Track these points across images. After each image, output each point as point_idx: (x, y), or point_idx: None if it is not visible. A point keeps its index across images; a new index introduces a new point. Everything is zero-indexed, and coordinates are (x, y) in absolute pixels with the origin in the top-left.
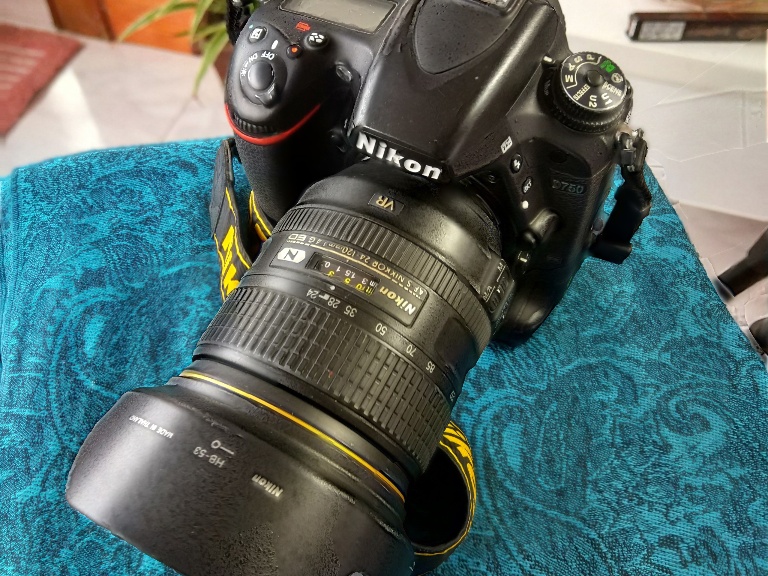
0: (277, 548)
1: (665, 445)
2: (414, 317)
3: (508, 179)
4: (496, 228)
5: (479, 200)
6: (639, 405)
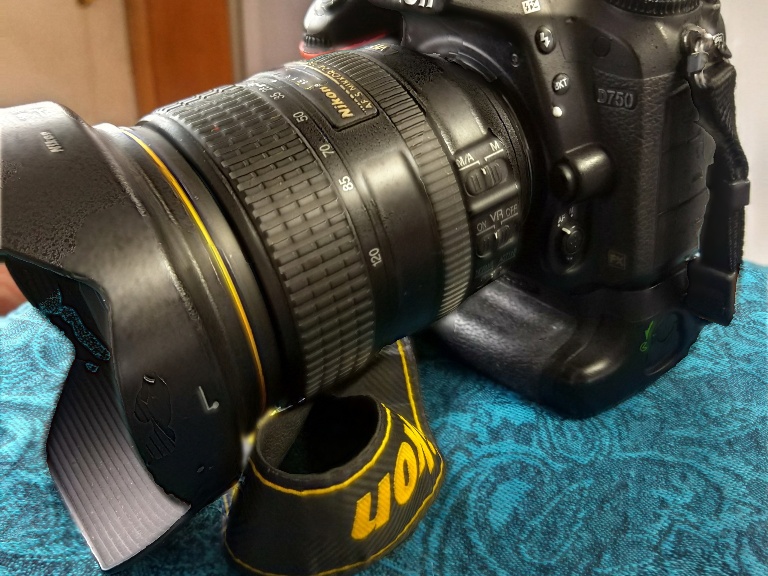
0: (8, 186)
1: (742, 573)
2: (348, 124)
3: (534, 62)
4: (524, 152)
5: (505, 104)
6: (719, 519)
